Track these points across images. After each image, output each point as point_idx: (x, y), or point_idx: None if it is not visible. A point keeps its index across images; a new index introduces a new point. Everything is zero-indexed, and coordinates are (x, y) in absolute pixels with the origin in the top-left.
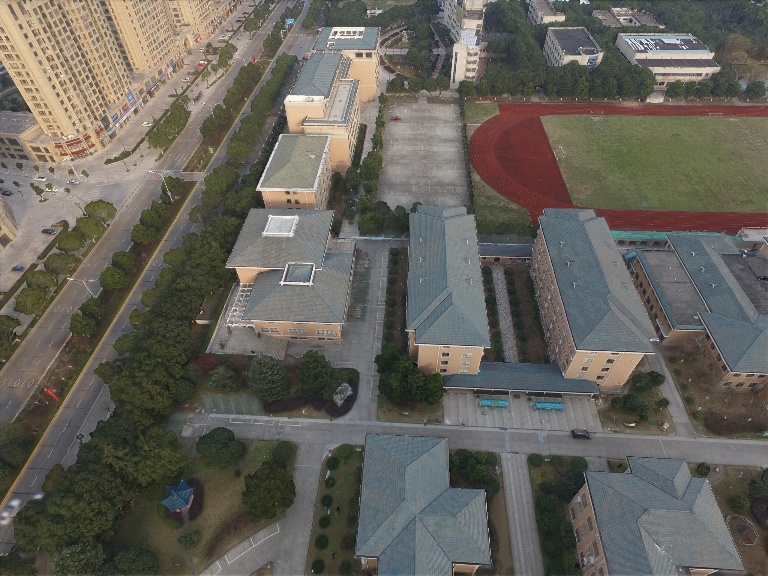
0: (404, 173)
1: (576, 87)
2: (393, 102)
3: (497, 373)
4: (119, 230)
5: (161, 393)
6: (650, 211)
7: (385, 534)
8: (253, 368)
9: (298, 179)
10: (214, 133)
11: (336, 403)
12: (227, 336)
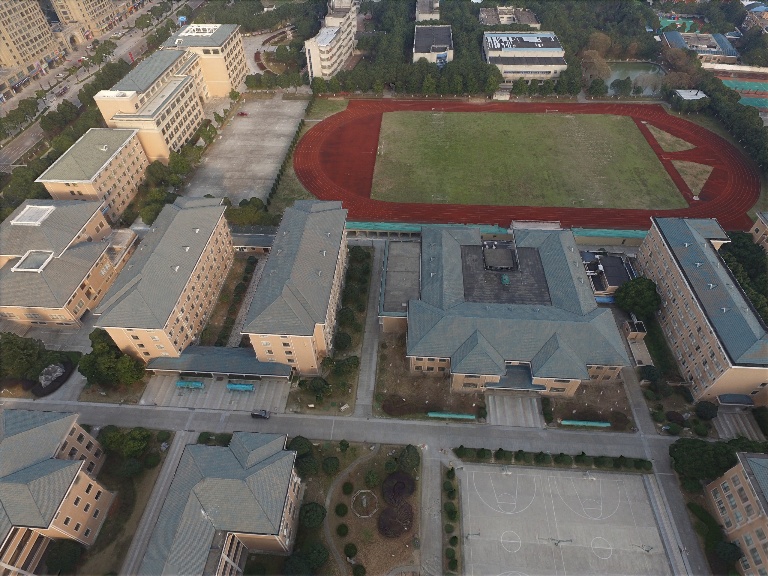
0: (223, 167)
1: (423, 84)
2: (249, 98)
3: (198, 356)
4: None
5: None
6: (440, 204)
7: None
8: None
9: (76, 171)
10: (53, 127)
11: (41, 384)
12: None
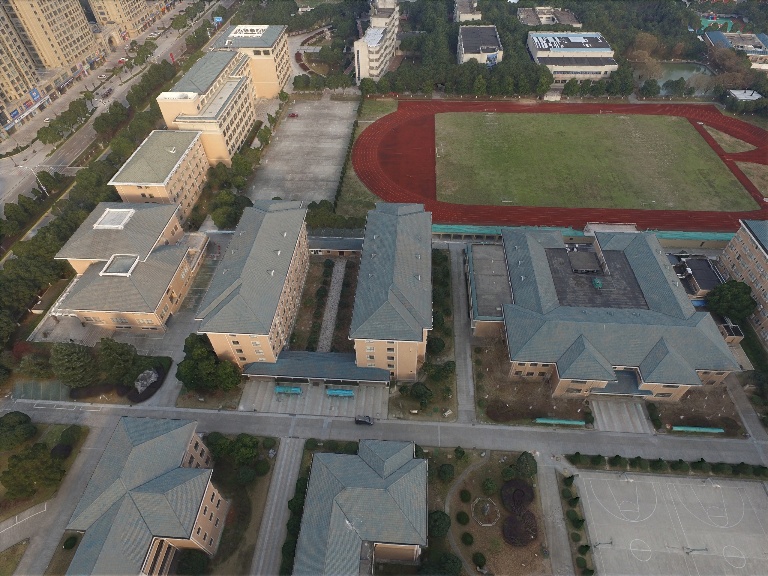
0: (283, 169)
1: (473, 85)
2: (296, 99)
3: (295, 361)
4: None
5: None
6: (509, 207)
7: (96, 509)
8: None
9: (149, 174)
10: (107, 129)
11: (137, 389)
12: (54, 325)
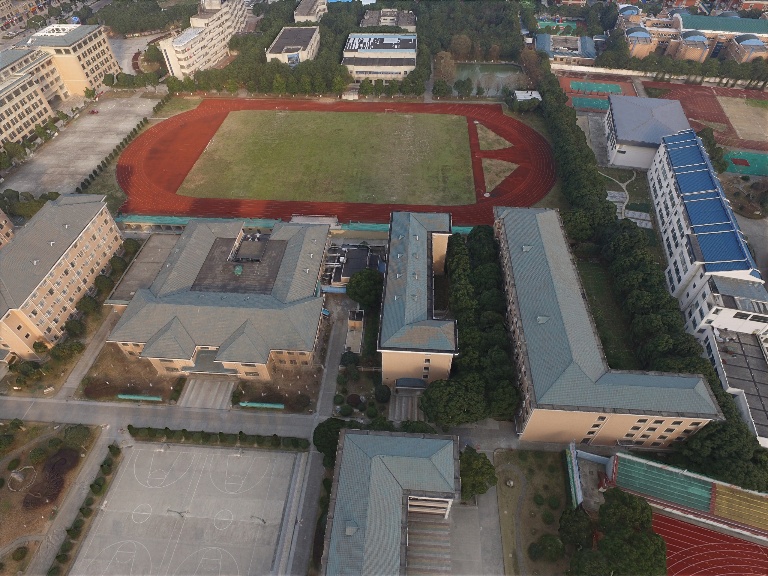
0: (50, 163)
1: None
2: (108, 97)
3: None
4: None
5: None
6: (239, 200)
7: None
8: None
9: None
10: None
11: None
12: None
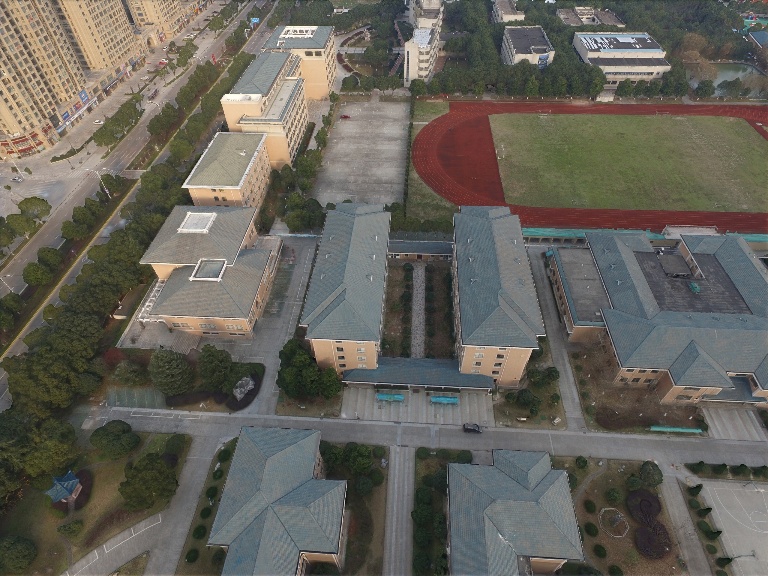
0: (344, 171)
1: (526, 86)
2: (346, 101)
3: (396, 368)
4: (54, 227)
5: (59, 386)
6: (581, 209)
7: (238, 523)
8: (152, 362)
9: (224, 176)
10: (161, 131)
11: (236, 397)
12: (140, 331)
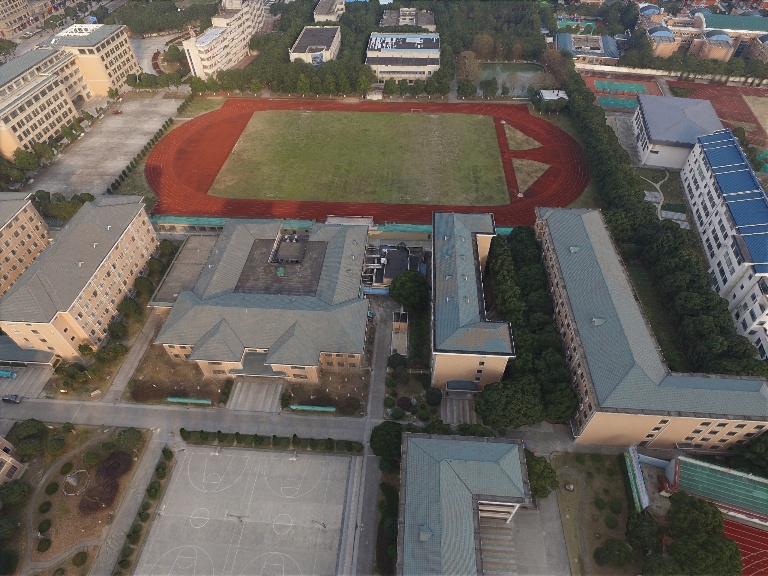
0: (77, 164)
1: None
2: (130, 97)
3: None
4: None
5: None
6: (271, 200)
7: None
8: None
9: None
10: None
11: None
12: None
